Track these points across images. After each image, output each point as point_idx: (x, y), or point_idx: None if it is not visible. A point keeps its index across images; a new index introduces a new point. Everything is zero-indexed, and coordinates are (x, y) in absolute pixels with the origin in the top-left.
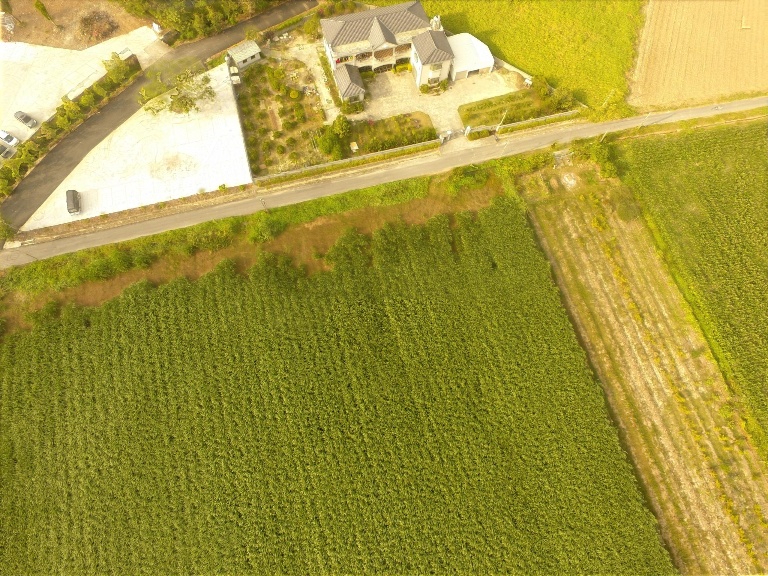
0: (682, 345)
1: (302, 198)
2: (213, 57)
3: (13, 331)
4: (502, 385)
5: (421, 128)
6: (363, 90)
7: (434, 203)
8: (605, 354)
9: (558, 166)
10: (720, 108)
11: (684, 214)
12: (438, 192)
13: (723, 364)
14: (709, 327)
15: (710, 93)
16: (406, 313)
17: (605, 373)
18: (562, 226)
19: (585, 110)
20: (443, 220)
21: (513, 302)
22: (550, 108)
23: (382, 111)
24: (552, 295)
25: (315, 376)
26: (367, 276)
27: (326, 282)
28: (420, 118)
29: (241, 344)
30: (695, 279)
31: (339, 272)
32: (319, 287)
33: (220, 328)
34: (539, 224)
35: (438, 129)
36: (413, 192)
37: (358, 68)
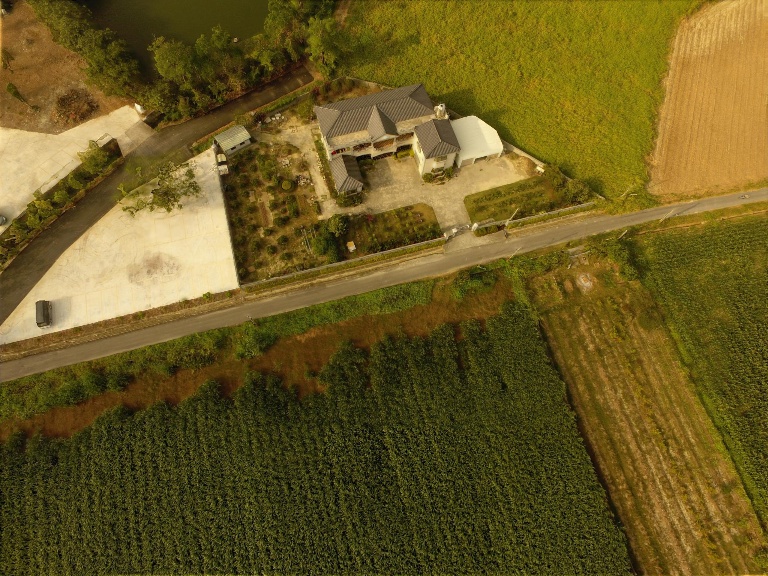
0: (711, 477)
1: (294, 306)
2: (199, 141)
3: None
4: (513, 532)
5: (424, 223)
6: (361, 184)
7: (438, 310)
8: (627, 490)
9: (573, 265)
10: (747, 197)
11: (711, 322)
12: (442, 297)
13: (757, 502)
14: (741, 457)
15: (736, 179)
16: (407, 445)
17: (627, 512)
18: (578, 336)
19: (602, 202)
20: (448, 332)
21: (525, 431)
22: (564, 201)
23: (382, 203)
24: (568, 422)
25: (306, 523)
26: (364, 400)
27: (319, 408)
28: (423, 211)
29: (224, 485)
30: (725, 401)
31: (334, 396)
32: (311, 414)
33: (201, 465)
34: (553, 334)
35: (442, 223)
36: (415, 298)
37: (356, 157)
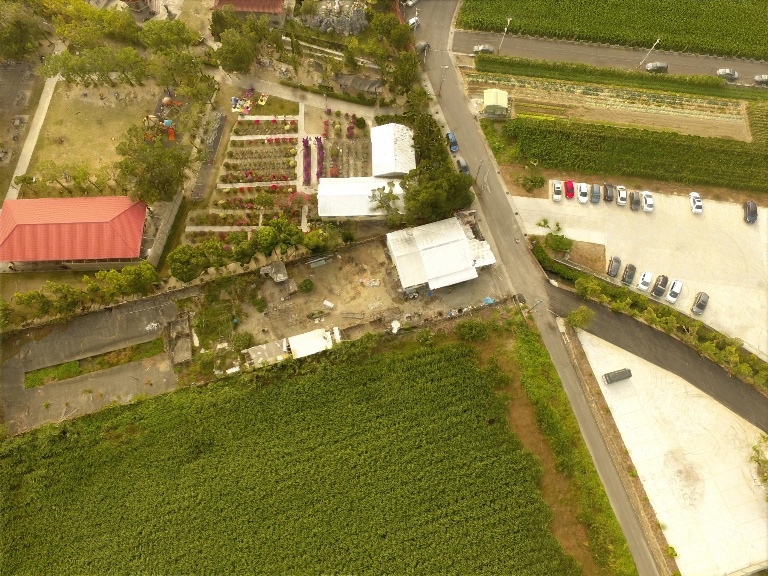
0: None
1: None
2: None
3: (478, 348)
4: None
5: None
6: None
7: None
8: None
9: None
10: None
11: None
12: None
13: None
14: None
15: None
16: None
17: None
18: None
19: None
20: None
21: None
22: None
23: None
24: None
25: None
26: None
27: None
28: None
29: None
30: None
31: None
32: None
33: None
34: None
35: None
36: None
37: None
